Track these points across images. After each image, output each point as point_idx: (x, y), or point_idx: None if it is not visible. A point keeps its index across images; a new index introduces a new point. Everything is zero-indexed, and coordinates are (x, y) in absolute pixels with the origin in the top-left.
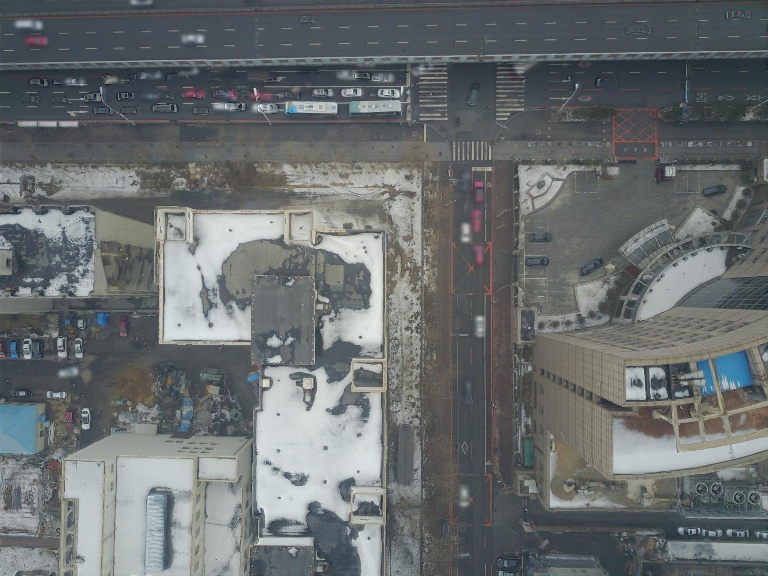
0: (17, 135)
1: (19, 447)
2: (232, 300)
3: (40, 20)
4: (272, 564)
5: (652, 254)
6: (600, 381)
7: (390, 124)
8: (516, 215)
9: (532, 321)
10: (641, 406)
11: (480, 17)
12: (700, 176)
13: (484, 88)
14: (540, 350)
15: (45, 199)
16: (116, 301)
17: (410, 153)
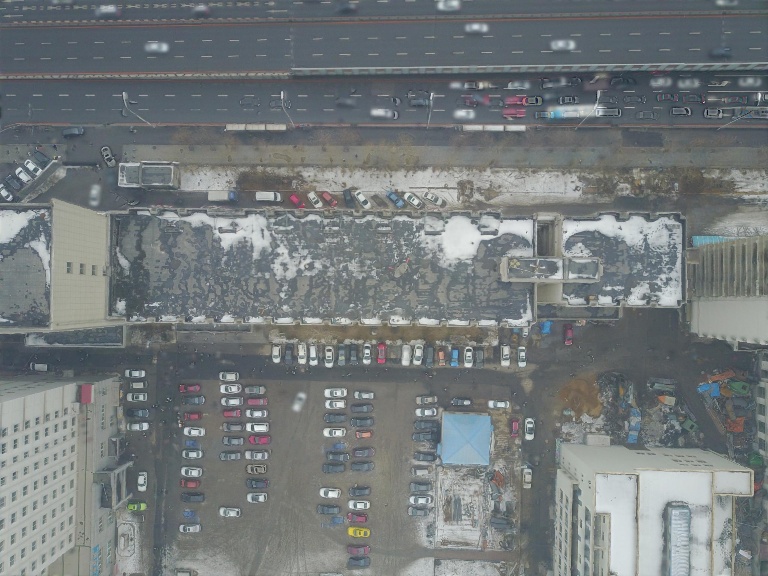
0: (472, 139)
1: (476, 458)
2: None
3: (492, 22)
4: None
5: None
6: None
7: None
8: None
9: None
10: None
11: None
12: None
13: None
14: None
15: (484, 204)
16: (572, 309)
17: None
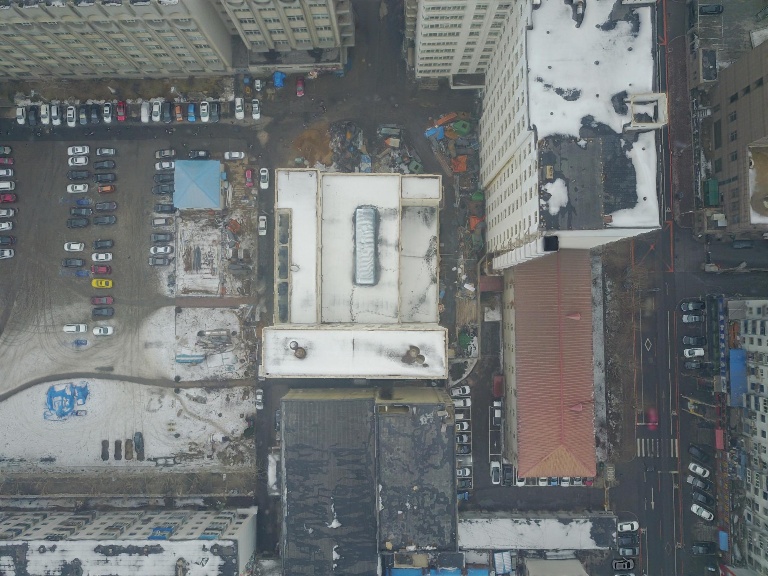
0: None
1: (204, 199)
2: None
3: None
4: (562, 156)
5: None
6: None
7: None
8: None
9: (713, 60)
10: None
11: None
12: None
13: None
14: (728, 80)
15: None
16: (296, 55)
17: None
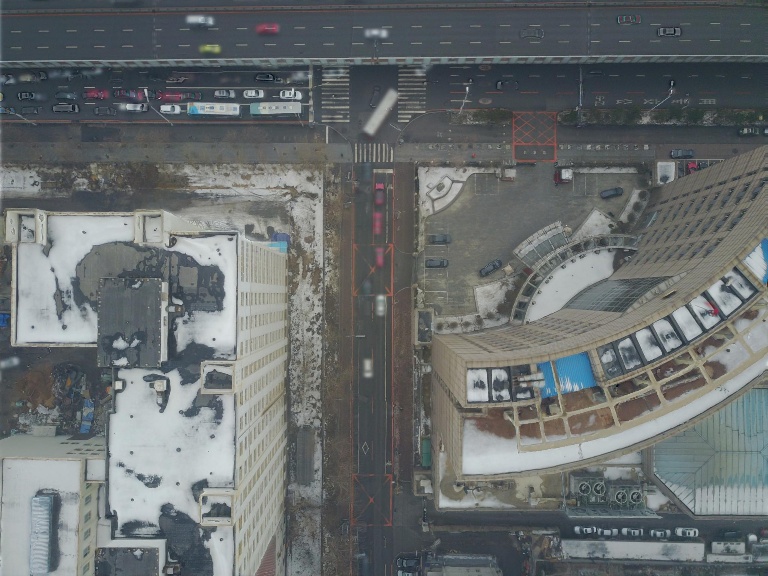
0: None
1: None
2: (86, 302)
3: None
4: (117, 566)
5: (546, 256)
6: (455, 382)
7: (292, 126)
8: (416, 217)
9: (429, 322)
10: (492, 407)
11: (377, 20)
12: (598, 179)
13: (386, 90)
14: (434, 351)
15: None
16: None
17: (312, 155)
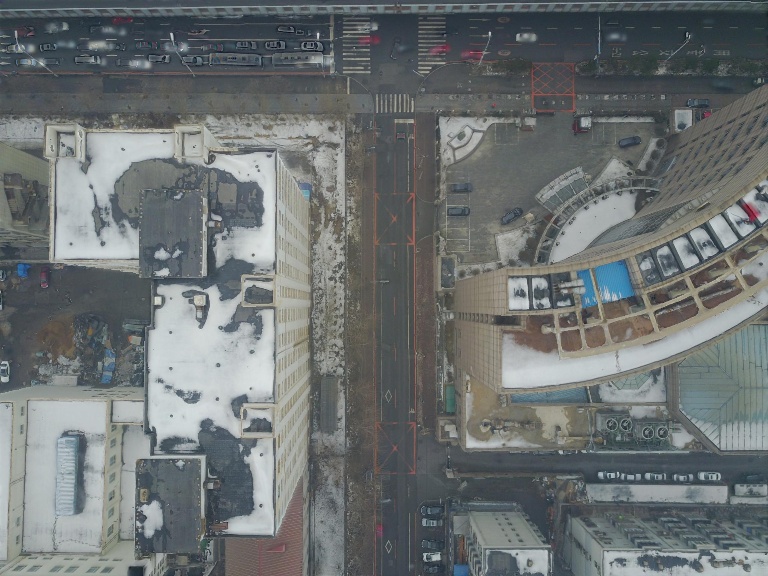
0: None
1: None
2: (125, 219)
3: None
4: (158, 477)
5: (567, 201)
6: (492, 299)
7: (314, 77)
8: (437, 166)
9: (452, 268)
10: (530, 321)
11: None
12: (616, 128)
13: (406, 42)
14: (458, 295)
15: None
16: (35, 251)
17: (333, 105)
